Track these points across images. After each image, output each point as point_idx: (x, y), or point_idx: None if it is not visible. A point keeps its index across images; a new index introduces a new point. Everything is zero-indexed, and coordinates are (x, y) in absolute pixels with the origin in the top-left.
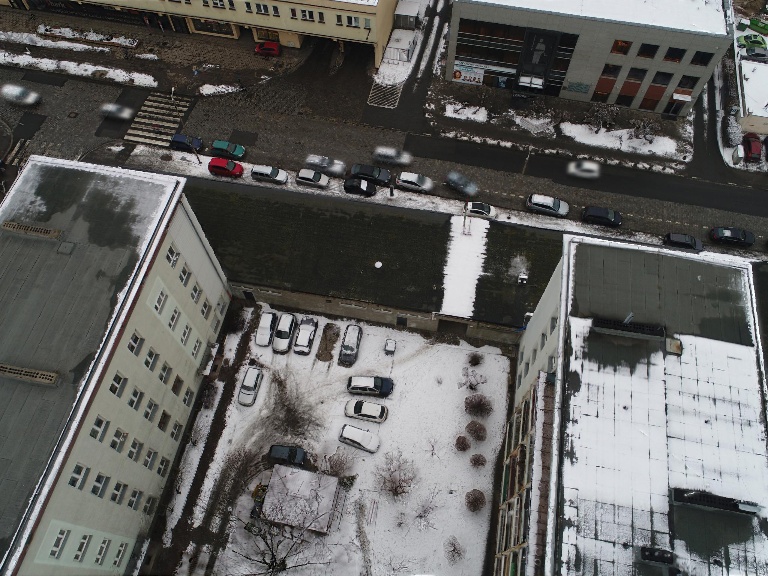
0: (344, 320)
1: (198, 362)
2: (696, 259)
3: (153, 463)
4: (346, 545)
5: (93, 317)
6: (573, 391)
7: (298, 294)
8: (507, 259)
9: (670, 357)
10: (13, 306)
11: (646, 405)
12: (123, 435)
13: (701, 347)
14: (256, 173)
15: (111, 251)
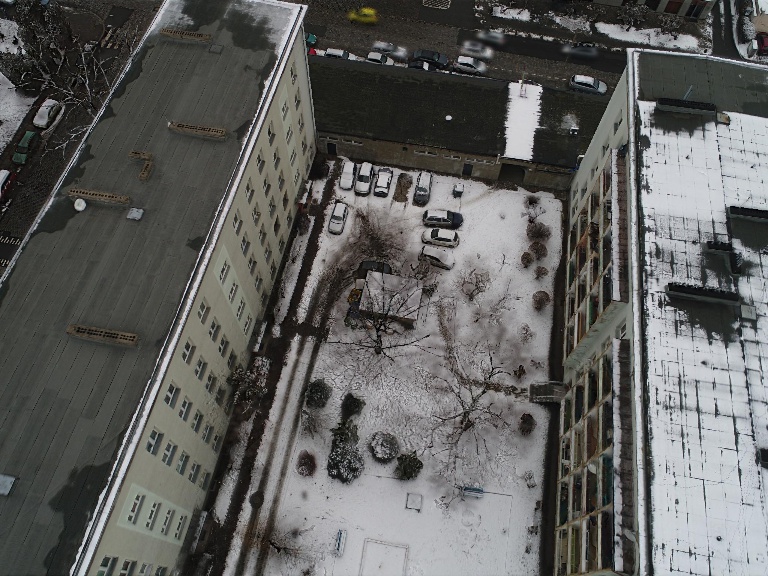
0: (416, 171)
1: (296, 191)
2: (737, 63)
3: (269, 259)
4: (445, 306)
5: (246, 96)
6: (645, 147)
7: (379, 142)
8: (559, 116)
9: (721, 125)
10: (179, 87)
11: (704, 156)
12: (257, 214)
13: (745, 120)
14: (329, 55)
15: (254, 52)
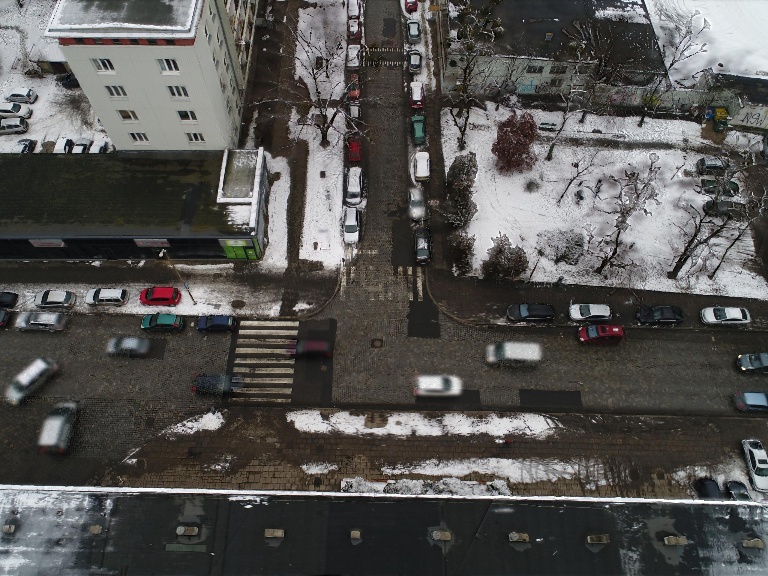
0: None
1: None
2: None
3: None
4: None
5: None
6: None
7: None
8: None
9: None
10: None
11: None
12: None
13: None
14: None
15: None
